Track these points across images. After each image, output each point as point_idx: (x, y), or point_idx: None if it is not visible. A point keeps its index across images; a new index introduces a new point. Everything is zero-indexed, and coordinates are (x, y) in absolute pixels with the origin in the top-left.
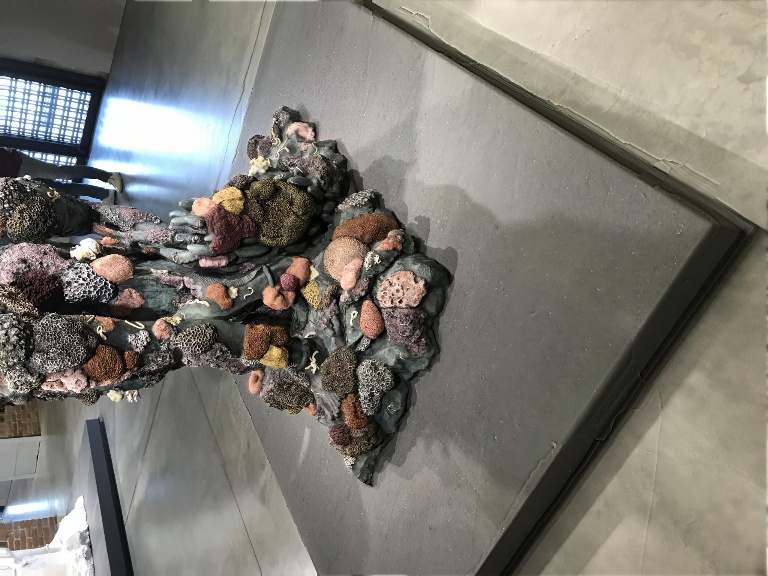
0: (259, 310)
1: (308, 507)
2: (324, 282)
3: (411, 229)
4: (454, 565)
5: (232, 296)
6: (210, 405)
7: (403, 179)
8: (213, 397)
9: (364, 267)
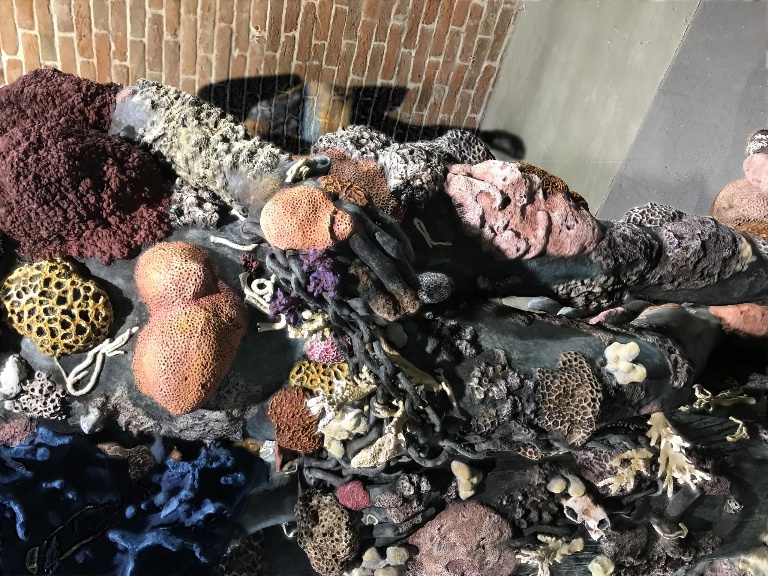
0: (752, 386)
1: None
2: None
3: None
4: None
5: None
6: None
7: None
8: None
9: (760, 149)
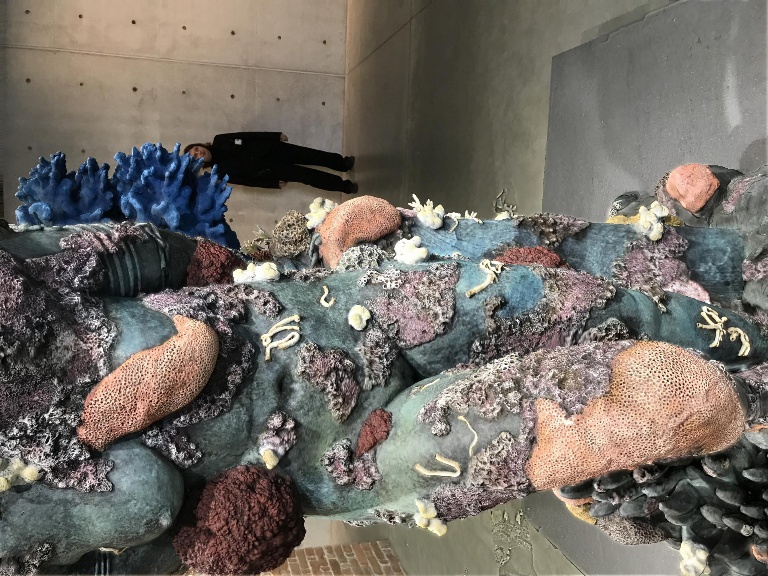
0: None
1: (686, 49)
2: None
3: None
4: None
5: None
6: None
7: None
8: None
9: None
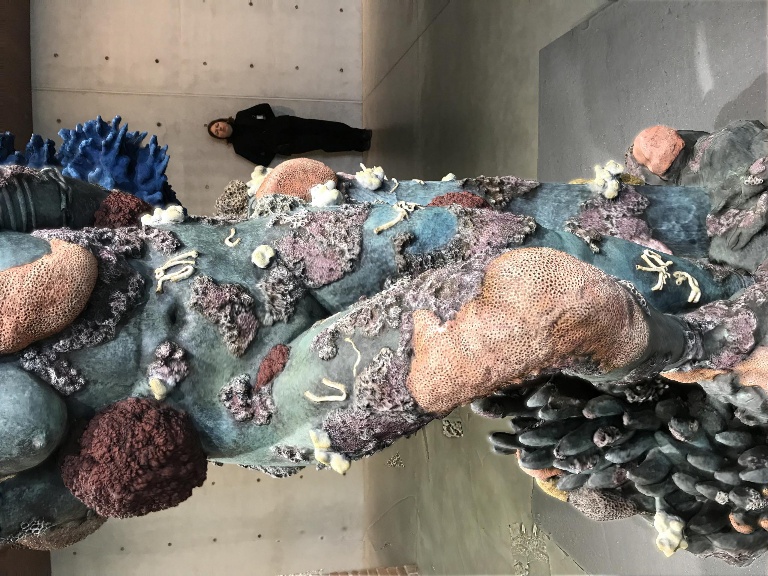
0: None
1: (658, 22)
2: None
3: None
4: None
5: None
6: None
7: None
8: None
9: None
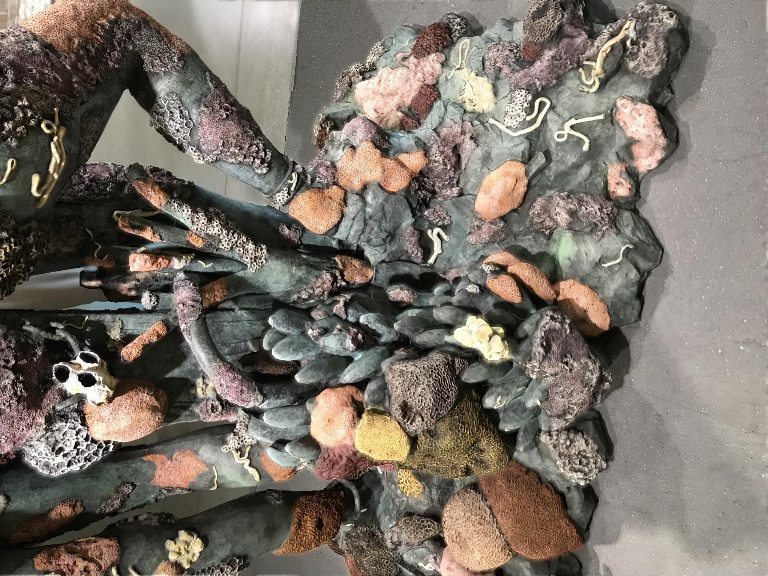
0: None
1: None
2: (433, 492)
3: (588, 558)
4: None
5: (300, 468)
6: (252, 14)
7: (653, 521)
8: (260, 15)
9: None
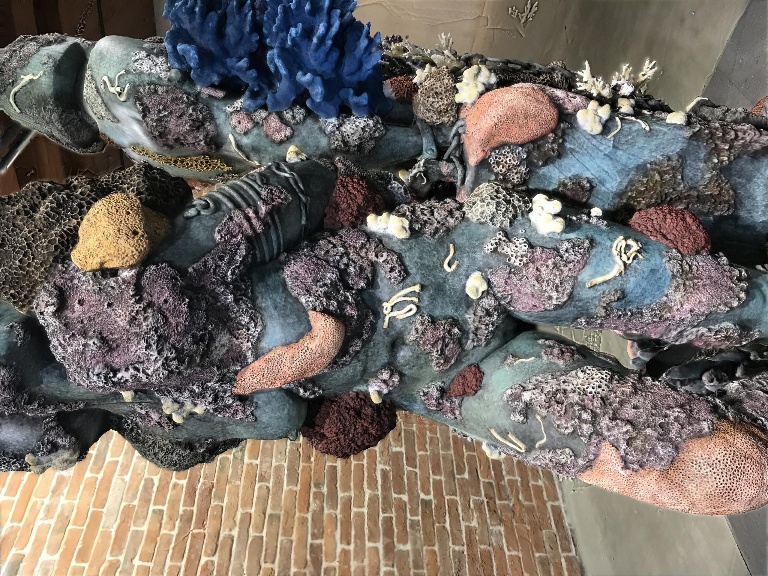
0: None
1: None
2: None
3: None
4: (760, 6)
5: None
6: None
7: None
8: None
9: None
